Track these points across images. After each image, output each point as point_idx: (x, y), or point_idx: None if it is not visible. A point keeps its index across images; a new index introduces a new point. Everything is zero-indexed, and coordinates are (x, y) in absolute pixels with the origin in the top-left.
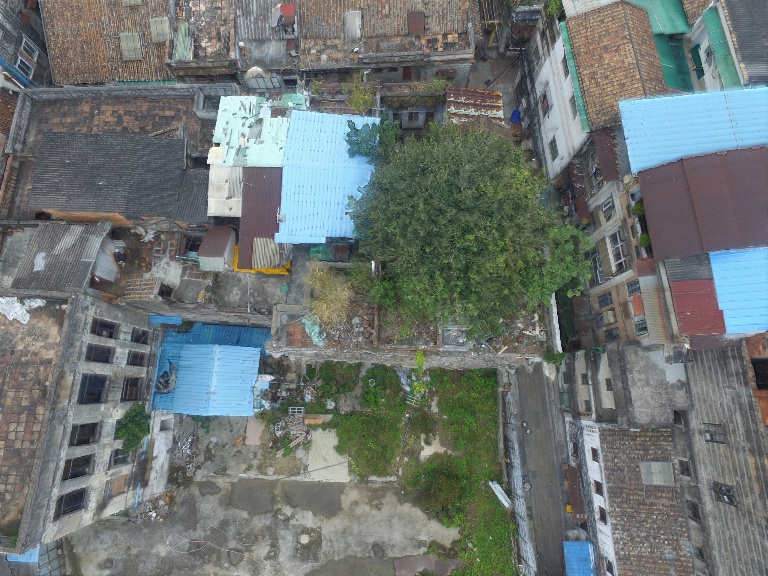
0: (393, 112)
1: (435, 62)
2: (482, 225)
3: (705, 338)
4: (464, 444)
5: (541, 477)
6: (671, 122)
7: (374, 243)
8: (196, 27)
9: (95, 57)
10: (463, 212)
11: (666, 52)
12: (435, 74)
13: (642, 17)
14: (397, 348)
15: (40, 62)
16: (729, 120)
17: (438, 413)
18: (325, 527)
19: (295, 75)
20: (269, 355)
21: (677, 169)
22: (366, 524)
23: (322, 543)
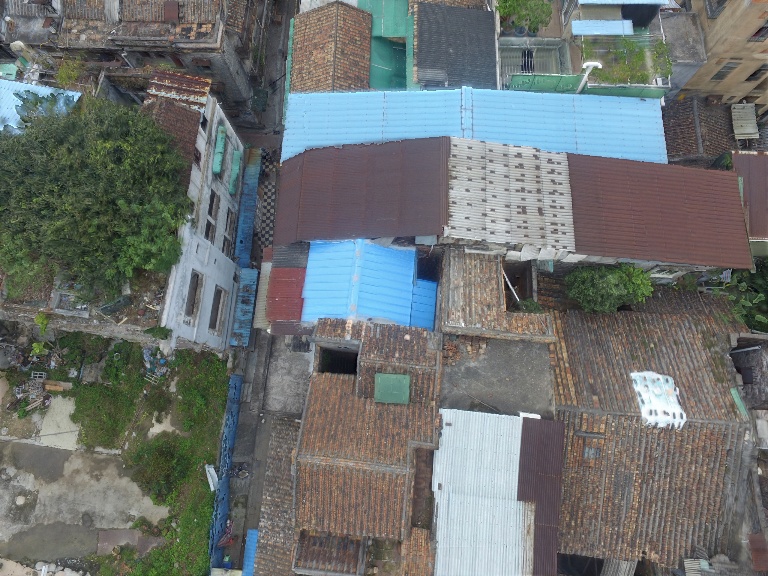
0: (133, 93)
1: (184, 49)
2: (46, 189)
3: (285, 324)
4: (191, 425)
5: (265, 467)
6: (329, 117)
7: None
8: None
9: None
10: (33, 176)
11: (386, 55)
12: None
13: (360, 18)
14: (23, 308)
15: None
16: (382, 119)
17: (175, 393)
18: (43, 491)
19: (60, 52)
20: None
21: (301, 159)
22: (82, 493)
23: (36, 506)
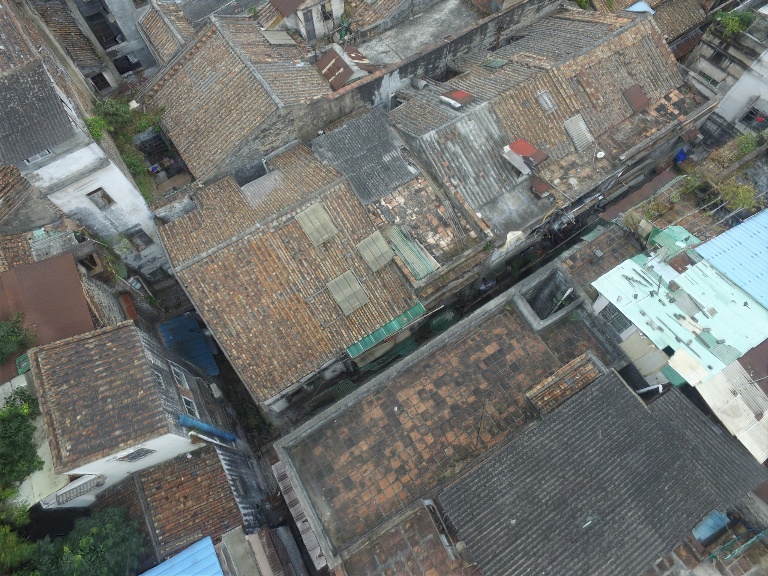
0: None
1: (685, 126)
2: None
3: None
4: None
5: None
6: None
7: None
8: (408, 225)
9: (302, 334)
10: None
11: None
12: (675, 140)
13: None
14: None
15: (190, 386)
16: None
17: None
18: None
19: None
20: None
21: None
22: None
23: None
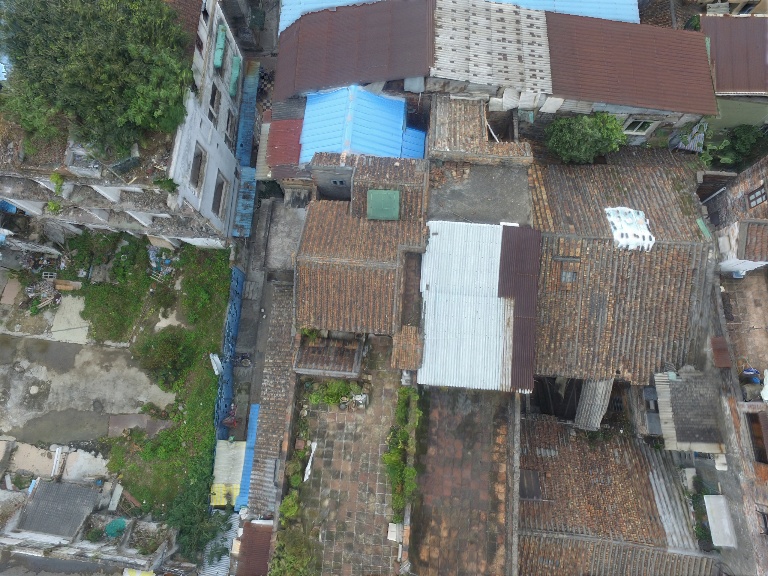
0: None
1: None
2: (61, 36)
3: (284, 168)
4: (195, 319)
5: None
6: None
7: (2, 63)
8: None
9: None
10: (49, 25)
11: None
12: None
13: None
14: (38, 171)
15: None
16: None
17: (180, 290)
18: (55, 381)
19: None
20: (11, 213)
21: (298, 25)
22: (93, 382)
23: (49, 395)
